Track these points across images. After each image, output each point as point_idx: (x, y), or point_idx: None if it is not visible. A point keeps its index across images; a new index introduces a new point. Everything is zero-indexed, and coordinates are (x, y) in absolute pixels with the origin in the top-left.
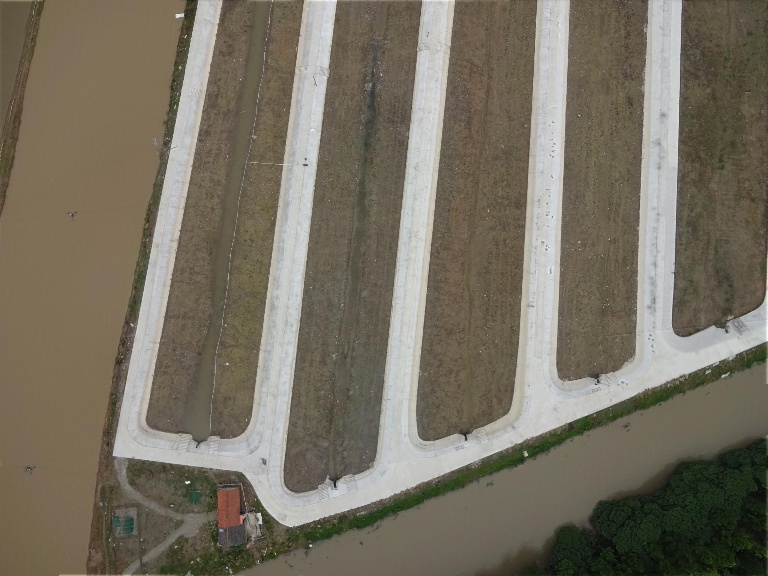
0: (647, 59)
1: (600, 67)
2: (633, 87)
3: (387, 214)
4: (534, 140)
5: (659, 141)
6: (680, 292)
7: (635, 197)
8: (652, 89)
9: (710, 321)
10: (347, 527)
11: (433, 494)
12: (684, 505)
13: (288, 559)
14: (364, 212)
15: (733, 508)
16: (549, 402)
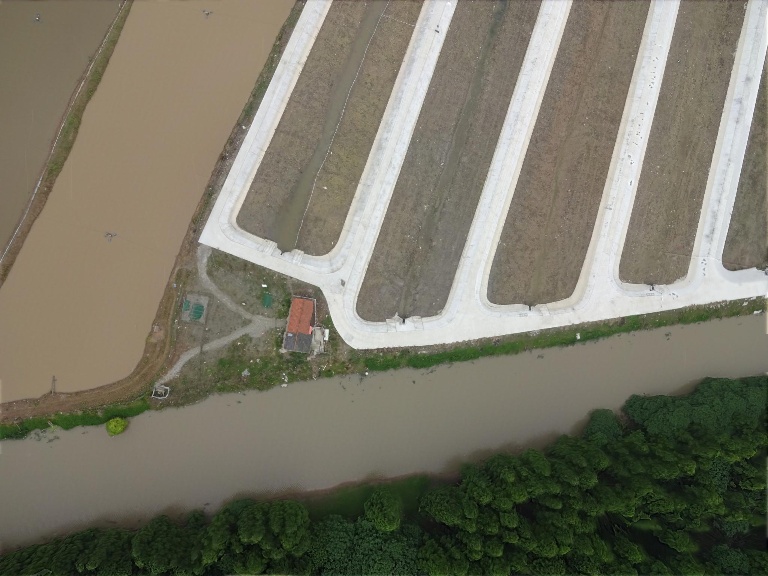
0: (742, 31)
1: (703, 27)
2: (726, 51)
3: (499, 96)
4: (638, 70)
5: (741, 100)
6: (733, 232)
7: (711, 142)
8: (742, 57)
9: (753, 263)
10: (405, 363)
11: (490, 352)
12: (711, 405)
13: (343, 381)
14: (478, 89)
15: (753, 416)
16: (609, 294)
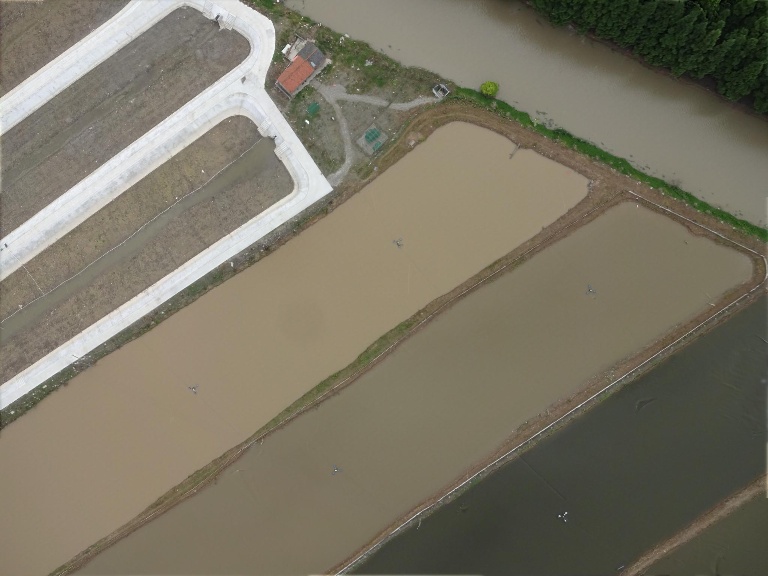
0: None
1: None
2: None
3: None
4: None
5: None
6: None
7: None
8: None
9: None
10: None
11: None
12: None
13: (301, 8)
14: (10, 175)
15: None
16: None
